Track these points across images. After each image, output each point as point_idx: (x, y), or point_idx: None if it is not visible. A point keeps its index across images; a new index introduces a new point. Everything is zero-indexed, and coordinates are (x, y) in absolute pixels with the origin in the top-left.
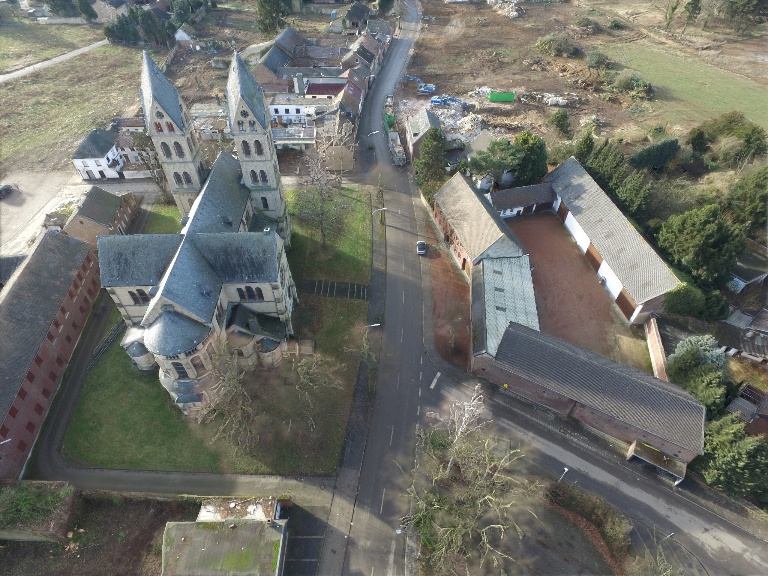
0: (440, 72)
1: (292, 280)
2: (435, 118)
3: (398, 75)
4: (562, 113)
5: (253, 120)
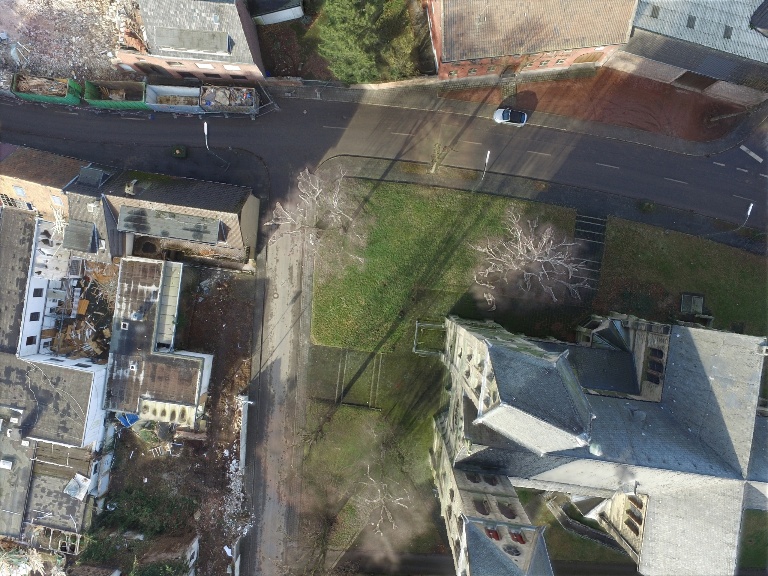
0: None
1: None
2: None
3: None
4: None
5: None
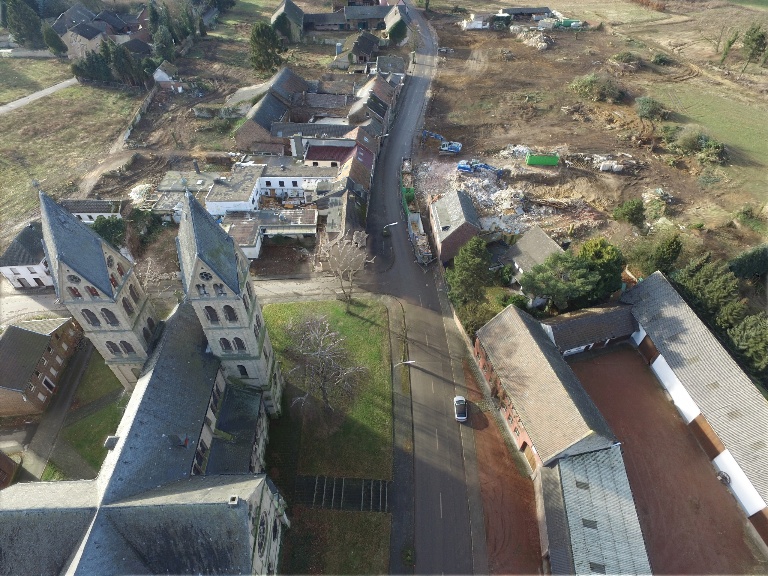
0: (464, 122)
1: (279, 508)
2: (468, 202)
3: (415, 126)
4: (637, 204)
5: (220, 283)
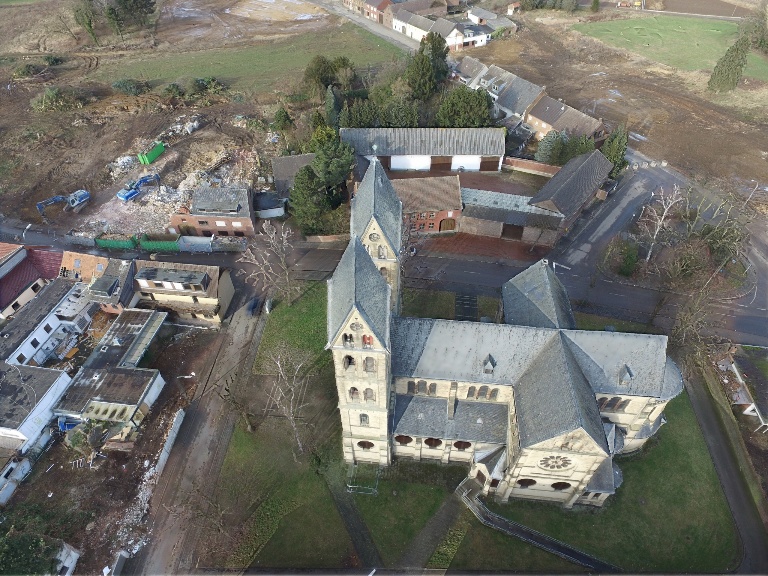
0: (29, 185)
1: None
2: None
3: None
4: (283, 111)
5: None
